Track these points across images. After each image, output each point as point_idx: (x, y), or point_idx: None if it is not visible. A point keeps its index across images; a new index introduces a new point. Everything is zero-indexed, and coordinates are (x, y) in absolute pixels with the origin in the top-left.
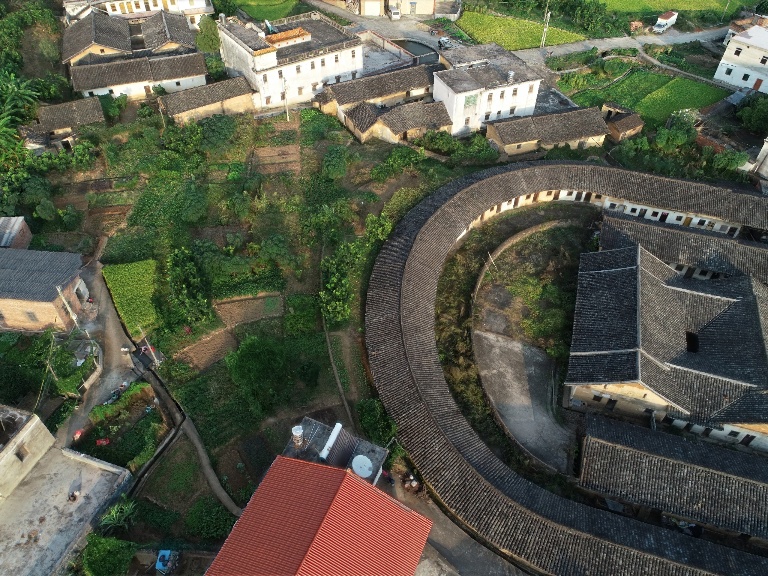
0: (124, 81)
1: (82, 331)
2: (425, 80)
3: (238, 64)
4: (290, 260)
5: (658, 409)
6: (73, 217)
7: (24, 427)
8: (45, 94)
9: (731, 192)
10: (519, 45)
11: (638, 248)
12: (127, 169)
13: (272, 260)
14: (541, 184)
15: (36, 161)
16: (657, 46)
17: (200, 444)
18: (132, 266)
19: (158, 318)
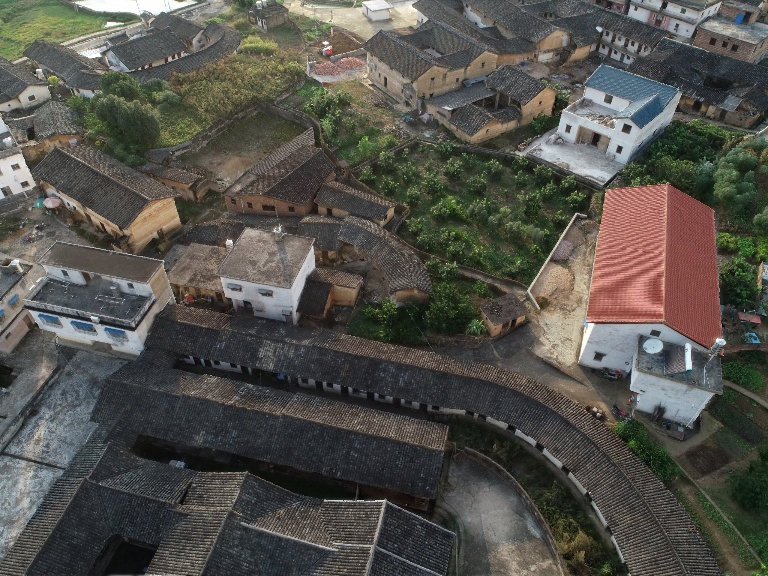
0: None
1: None
2: None
3: None
4: None
5: None
6: None
7: None
8: None
9: None
10: None
11: None
12: None
13: None
14: None
15: None
16: None
17: None
18: None
19: None
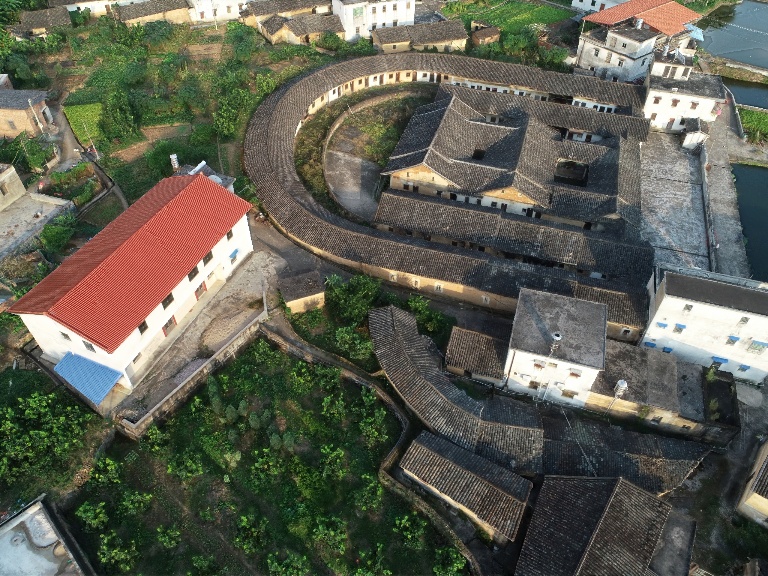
0: None
1: (47, 140)
2: (327, 0)
3: None
4: (198, 102)
5: (444, 190)
6: (44, 77)
7: (5, 171)
8: (26, 6)
9: (540, 70)
10: None
11: (452, 97)
12: (87, 55)
13: (186, 103)
14: (400, 66)
15: (18, 44)
16: None
17: (123, 198)
18: (85, 106)
19: (101, 134)
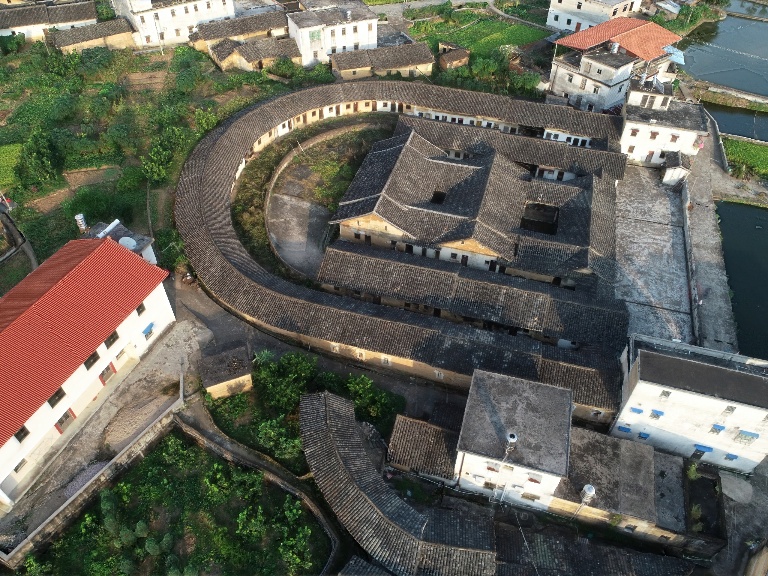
0: (24, 23)
1: None
2: (283, 22)
3: (123, 10)
4: (129, 142)
5: (399, 240)
6: None
7: None
8: None
9: (509, 99)
10: (385, 0)
11: (411, 133)
12: (14, 86)
13: (115, 143)
14: (357, 95)
15: None
16: (507, 1)
17: (33, 257)
18: (2, 148)
19: (16, 180)
